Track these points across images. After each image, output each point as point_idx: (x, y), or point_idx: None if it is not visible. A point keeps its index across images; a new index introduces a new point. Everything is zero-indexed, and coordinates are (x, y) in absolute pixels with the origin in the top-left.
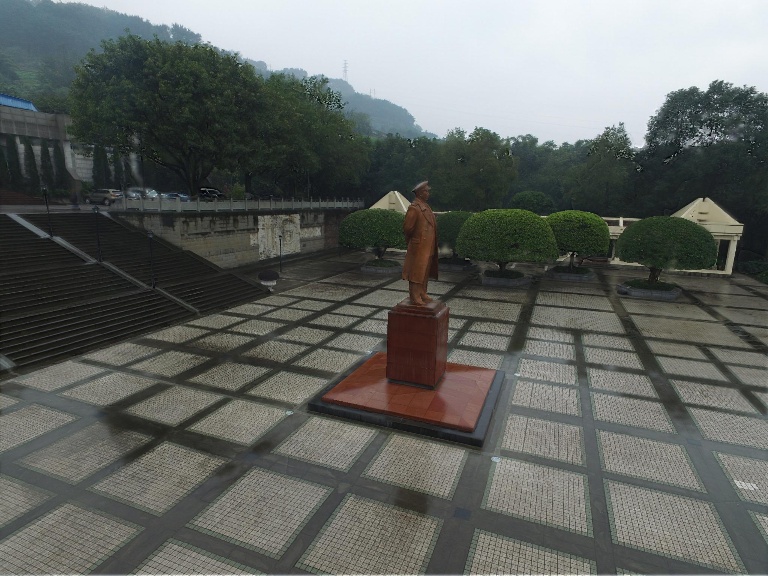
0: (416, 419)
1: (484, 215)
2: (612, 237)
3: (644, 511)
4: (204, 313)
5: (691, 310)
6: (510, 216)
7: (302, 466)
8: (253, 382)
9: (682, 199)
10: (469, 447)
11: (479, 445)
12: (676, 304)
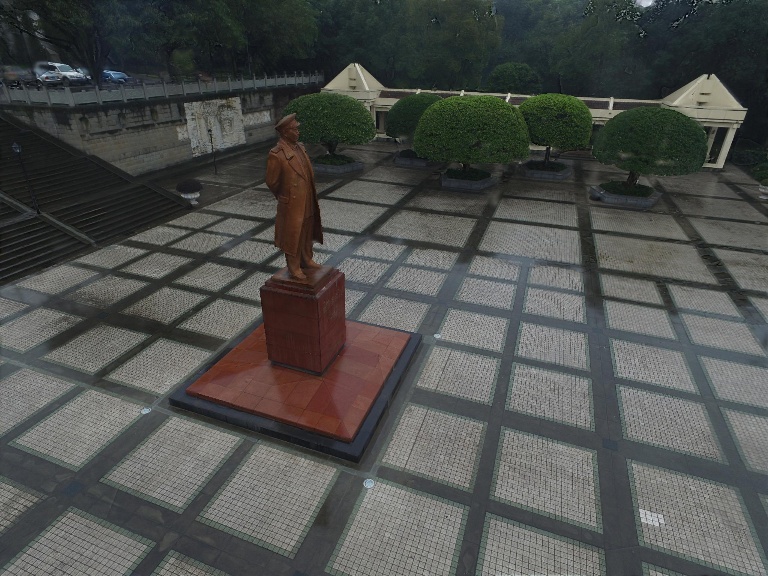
0: (289, 423)
1: (445, 104)
2: (599, 122)
3: (519, 569)
4: (102, 243)
5: (664, 224)
6: (474, 106)
7: (130, 504)
8: (120, 359)
9: (684, 75)
10: (343, 463)
11: (355, 461)
12: (650, 214)
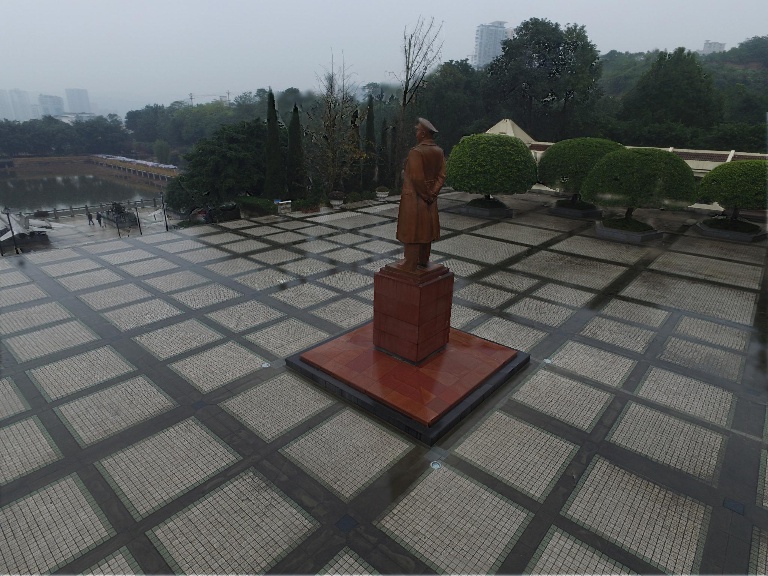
0: None
1: None
2: None
3: None
4: None
5: None
6: None
7: (524, 323)
8: (617, 412)
9: None
10: None
11: None
12: None
